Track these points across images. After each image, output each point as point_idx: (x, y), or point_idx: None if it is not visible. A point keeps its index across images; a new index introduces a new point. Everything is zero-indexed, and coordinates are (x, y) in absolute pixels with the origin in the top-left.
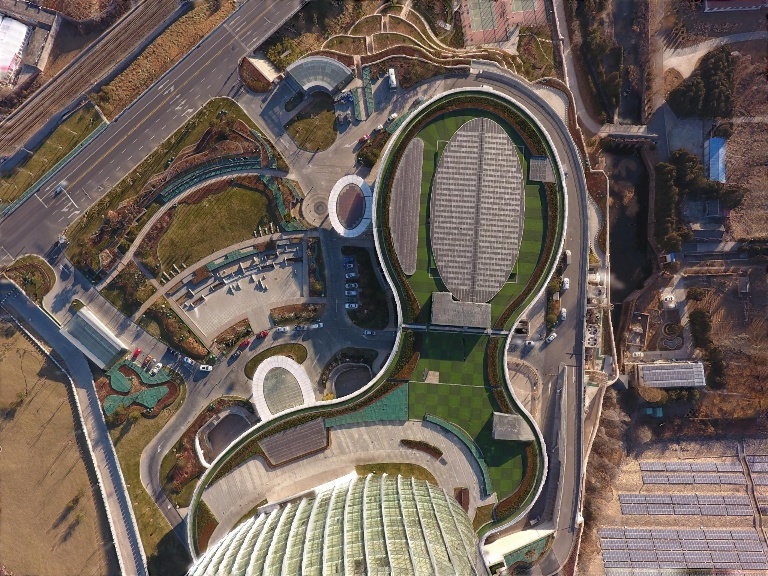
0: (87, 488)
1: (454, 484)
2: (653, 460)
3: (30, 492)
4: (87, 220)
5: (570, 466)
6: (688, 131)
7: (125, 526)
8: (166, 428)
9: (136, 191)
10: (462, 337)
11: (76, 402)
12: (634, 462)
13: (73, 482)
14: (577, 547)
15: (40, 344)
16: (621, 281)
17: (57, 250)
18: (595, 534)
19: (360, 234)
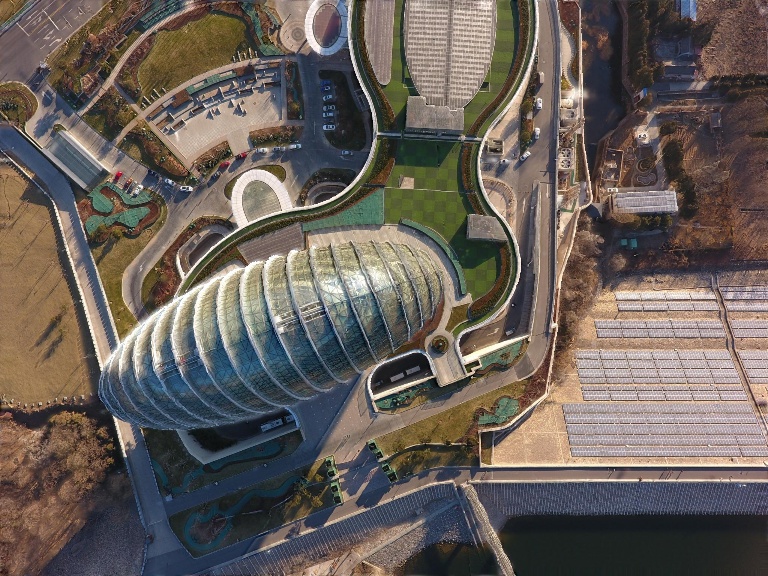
0: (70, 306)
1: None
2: (628, 291)
3: (14, 311)
4: (68, 47)
5: (544, 276)
6: None
7: (107, 341)
8: (147, 248)
9: (116, 19)
10: (436, 144)
11: (58, 223)
12: (610, 293)
13: (56, 301)
14: (551, 351)
15: (23, 169)
16: (596, 122)
17: (39, 77)
18: (570, 351)
19: (337, 55)
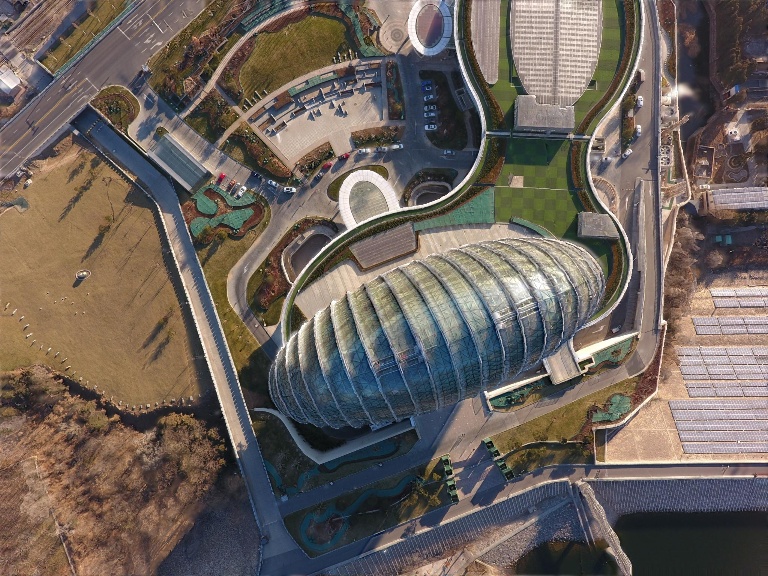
0: (176, 308)
1: None
2: (723, 288)
3: (120, 313)
4: (169, 51)
5: (651, 273)
6: None
7: (215, 342)
8: (252, 249)
9: (217, 22)
10: (545, 143)
11: (163, 225)
12: (704, 290)
13: (162, 303)
14: (661, 348)
15: (125, 172)
16: None
17: (140, 80)
18: None
19: (438, 55)
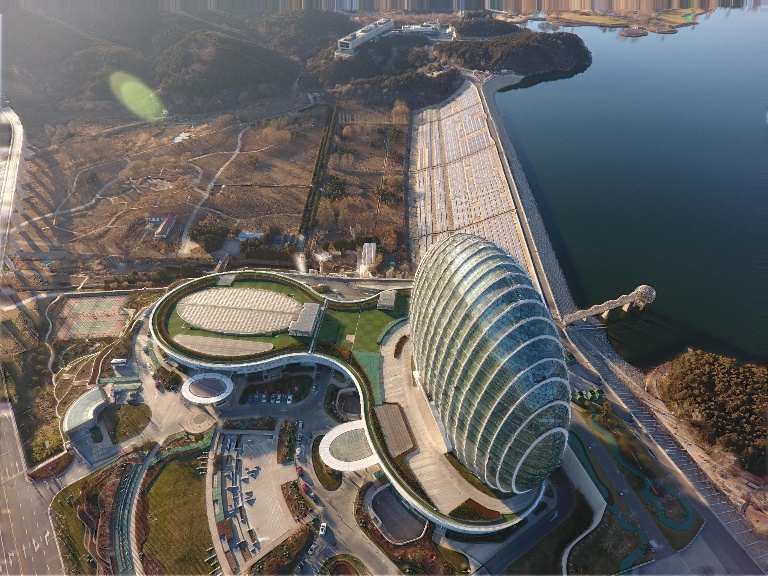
0: None
1: None
2: None
3: None
4: None
5: None
6: (230, 246)
7: None
8: None
9: None
10: (324, 322)
11: None
12: None
13: None
14: None
15: None
16: None
17: None
18: None
19: None
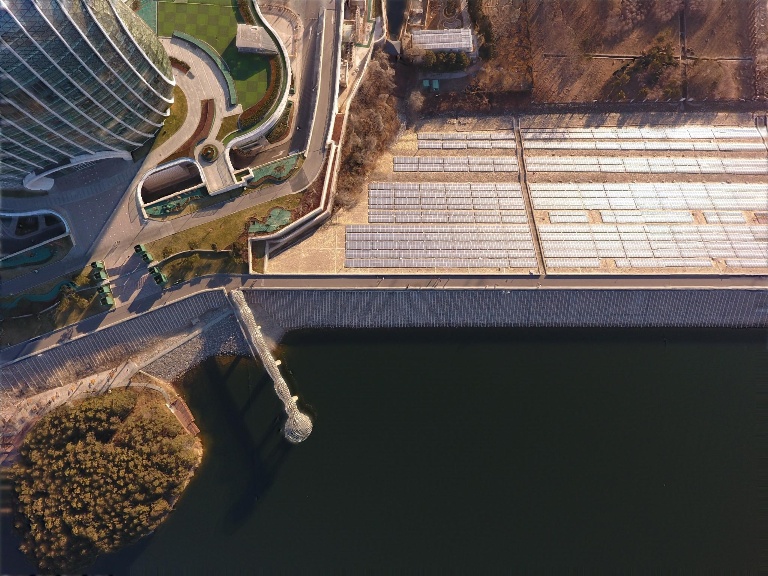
0: None
1: (201, 97)
2: (431, 132)
3: None
4: None
5: (324, 96)
6: None
7: None
8: None
9: None
10: None
11: None
12: (413, 134)
13: None
14: (326, 166)
15: None
16: None
17: None
18: None
19: None
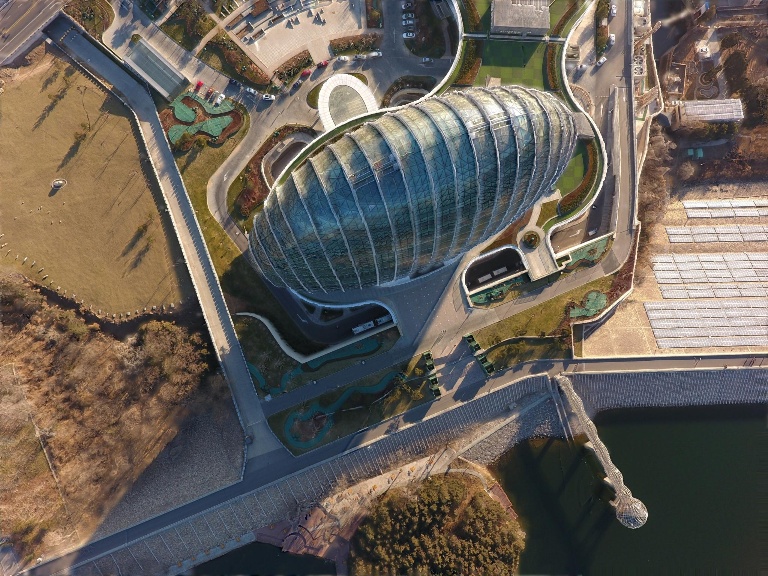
0: (155, 216)
1: None
2: (695, 200)
3: (98, 222)
4: None
5: (625, 176)
6: None
7: (195, 249)
8: (231, 157)
9: None
10: (521, 45)
11: (141, 133)
12: (677, 202)
13: (141, 211)
14: (636, 247)
15: (101, 81)
16: (658, 39)
17: None
18: None
19: None
